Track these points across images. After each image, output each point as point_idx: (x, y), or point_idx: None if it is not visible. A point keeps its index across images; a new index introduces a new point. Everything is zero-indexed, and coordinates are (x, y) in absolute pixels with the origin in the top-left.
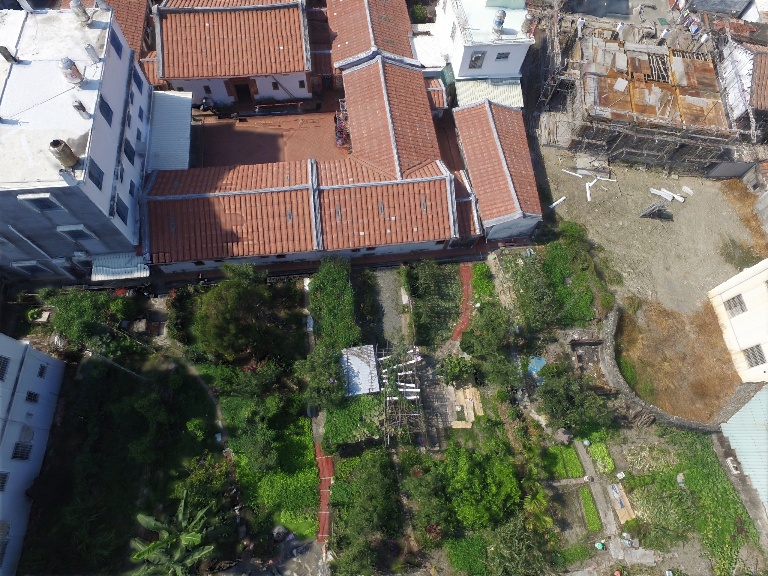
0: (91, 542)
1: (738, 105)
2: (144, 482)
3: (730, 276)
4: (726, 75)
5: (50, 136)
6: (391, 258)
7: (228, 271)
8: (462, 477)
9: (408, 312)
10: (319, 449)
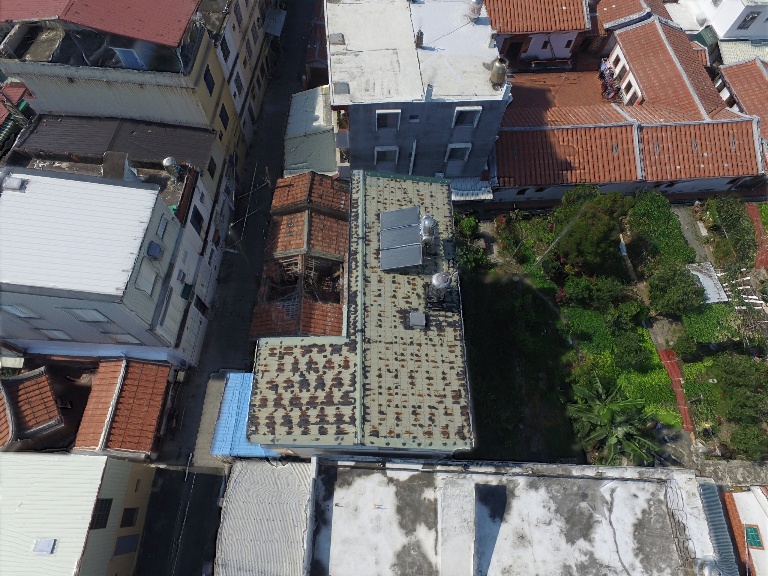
0: (497, 417)
1: None
2: (519, 373)
3: None
4: None
5: (467, 61)
6: (681, 196)
7: (564, 196)
8: None
9: (713, 242)
10: (662, 354)
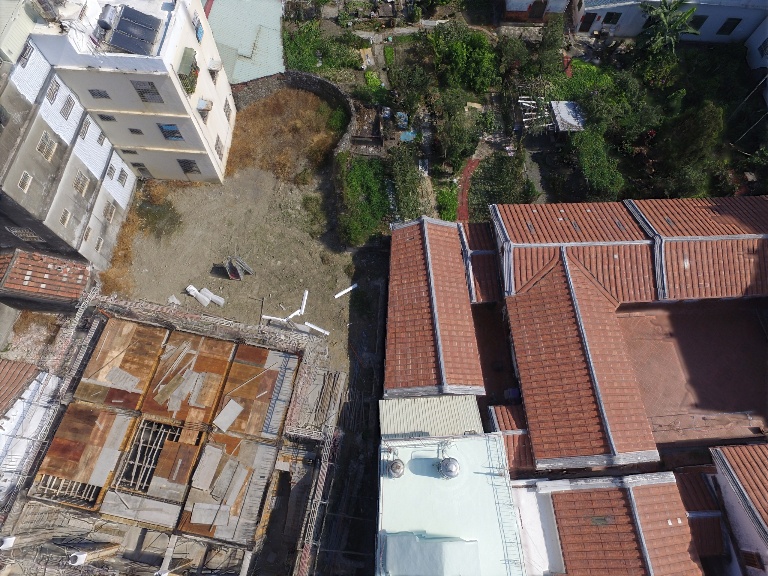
0: None
1: (43, 393)
2: None
3: (187, 201)
4: (8, 474)
5: None
6: None
7: None
8: (488, 55)
9: None
10: None
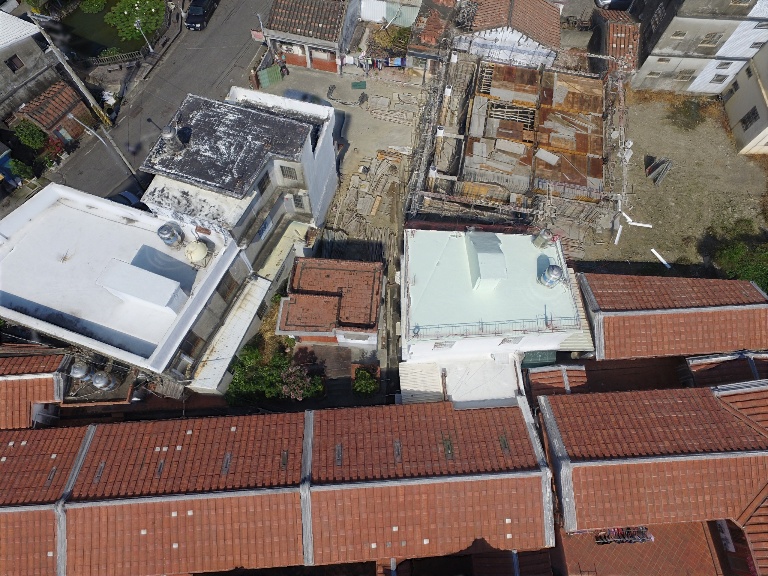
0: None
1: (540, 61)
2: None
3: (710, 131)
4: None
5: None
6: None
7: None
8: None
9: None
10: None
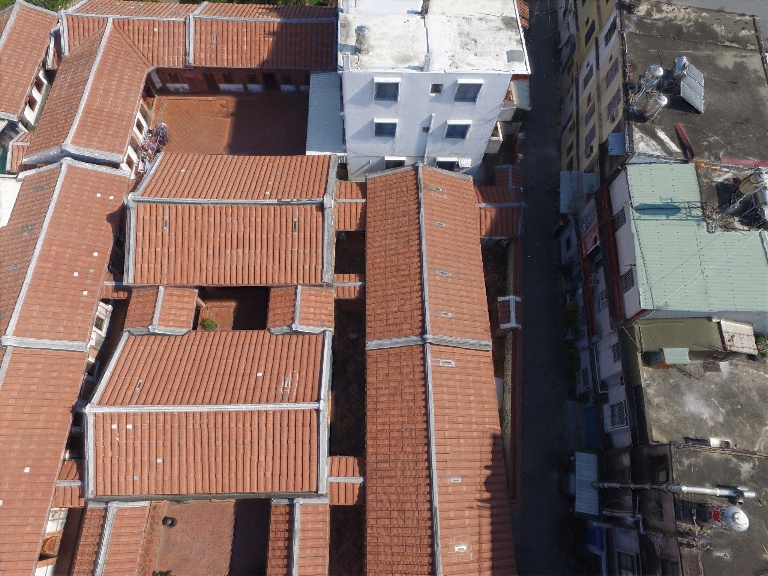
0: None
1: None
2: None
3: None
4: None
5: None
6: None
7: (280, 2)
8: None
9: None
10: None
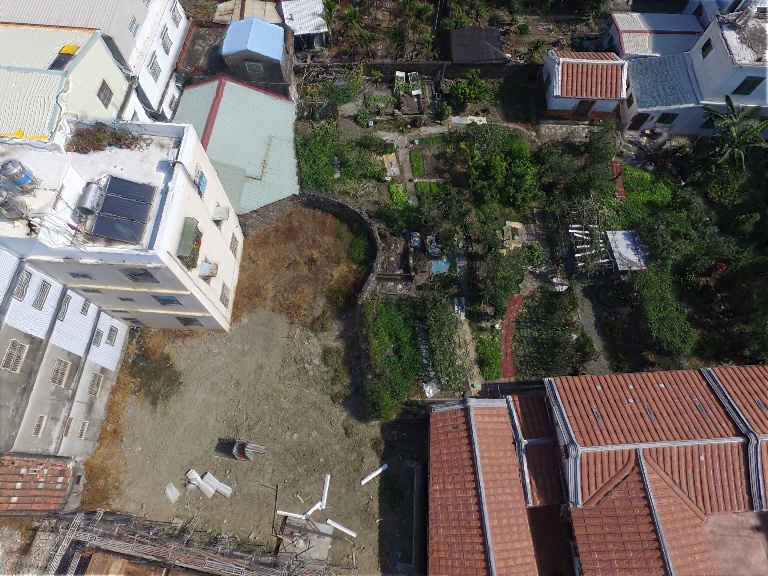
0: None
1: None
2: None
3: (187, 354)
4: None
5: None
6: None
7: None
8: (531, 171)
9: None
10: None
